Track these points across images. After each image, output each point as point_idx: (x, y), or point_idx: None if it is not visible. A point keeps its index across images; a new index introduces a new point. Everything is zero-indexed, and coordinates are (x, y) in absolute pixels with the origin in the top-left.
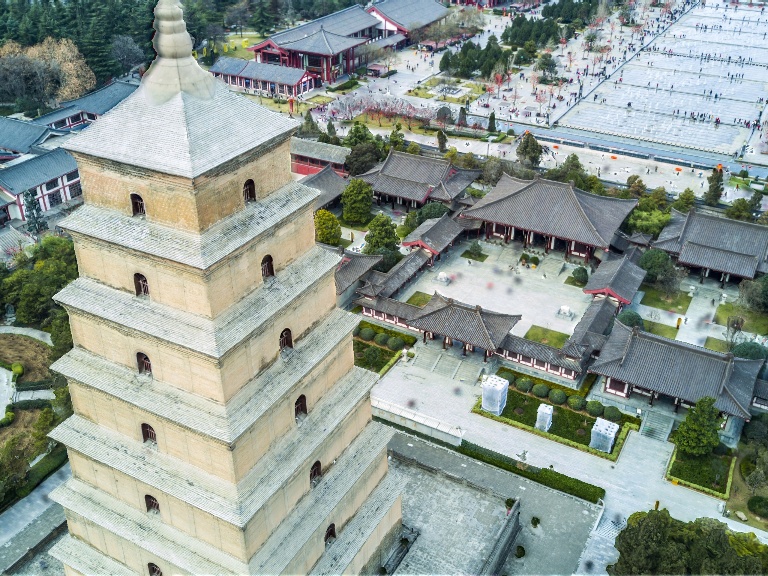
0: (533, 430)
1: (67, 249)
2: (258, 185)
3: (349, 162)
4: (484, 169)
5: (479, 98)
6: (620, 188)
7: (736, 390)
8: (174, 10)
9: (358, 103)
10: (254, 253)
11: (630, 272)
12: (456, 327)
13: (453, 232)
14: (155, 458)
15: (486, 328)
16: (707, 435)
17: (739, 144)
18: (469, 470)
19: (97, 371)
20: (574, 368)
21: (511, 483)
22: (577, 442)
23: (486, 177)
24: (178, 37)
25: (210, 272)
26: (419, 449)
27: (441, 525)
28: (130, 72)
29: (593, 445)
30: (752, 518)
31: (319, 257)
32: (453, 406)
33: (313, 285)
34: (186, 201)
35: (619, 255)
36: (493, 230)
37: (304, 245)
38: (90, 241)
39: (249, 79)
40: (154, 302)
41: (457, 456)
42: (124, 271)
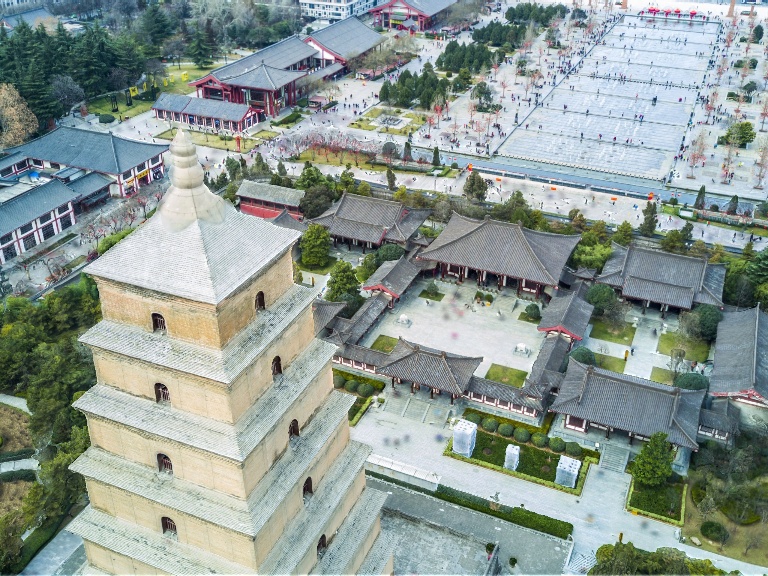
0: (502, 470)
1: (34, 311)
2: (267, 295)
3: (303, 205)
4: (435, 209)
5: (420, 128)
6: (563, 222)
7: (684, 422)
8: (189, 147)
9: (304, 139)
10: (266, 358)
11: (579, 308)
12: (423, 373)
13: (411, 274)
14: (176, 548)
15: (452, 373)
16: (661, 467)
17: (666, 169)
18: (447, 514)
19: (117, 470)
20: (535, 407)
21: (487, 525)
22: (543, 479)
23: (437, 217)
24: (192, 170)
25: (231, 384)
26: (398, 496)
27: (428, 574)
28: (71, 111)
29: (558, 481)
30: (705, 542)
31: (319, 349)
32: (425, 450)
33: (315, 376)
34: (208, 321)
35: (567, 290)
36: (448, 269)
37: (305, 340)
38: (111, 354)
39: (193, 116)
40: (175, 408)
41: (435, 501)
42: (145, 381)
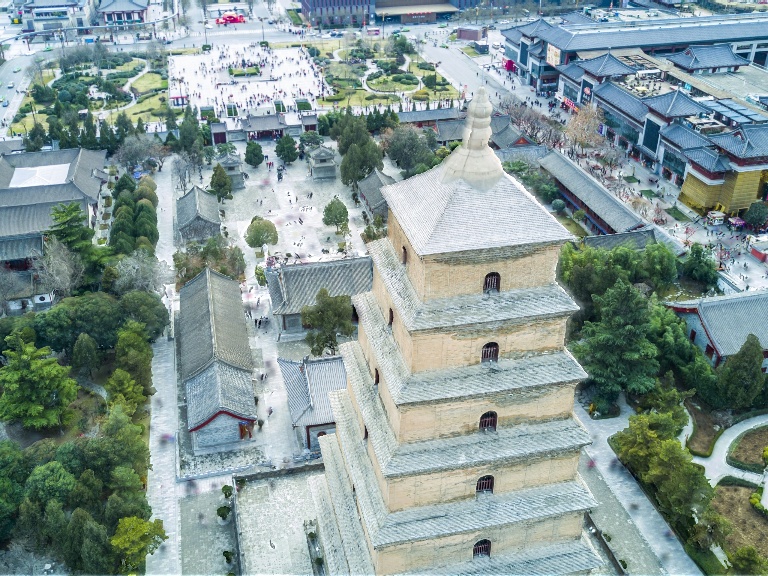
0: None
1: None
2: None
3: None
4: None
5: None
6: None
7: None
8: None
9: None
10: None
11: None
12: None
13: None
14: None
15: None
16: None
17: None
18: None
19: None
20: None
21: None
22: None
23: None
24: None
25: None
26: None
27: None
28: None
29: None
30: None
31: None
32: None
33: None
34: None
35: None
36: None
37: None
38: None
39: None
40: None
41: None
42: None
